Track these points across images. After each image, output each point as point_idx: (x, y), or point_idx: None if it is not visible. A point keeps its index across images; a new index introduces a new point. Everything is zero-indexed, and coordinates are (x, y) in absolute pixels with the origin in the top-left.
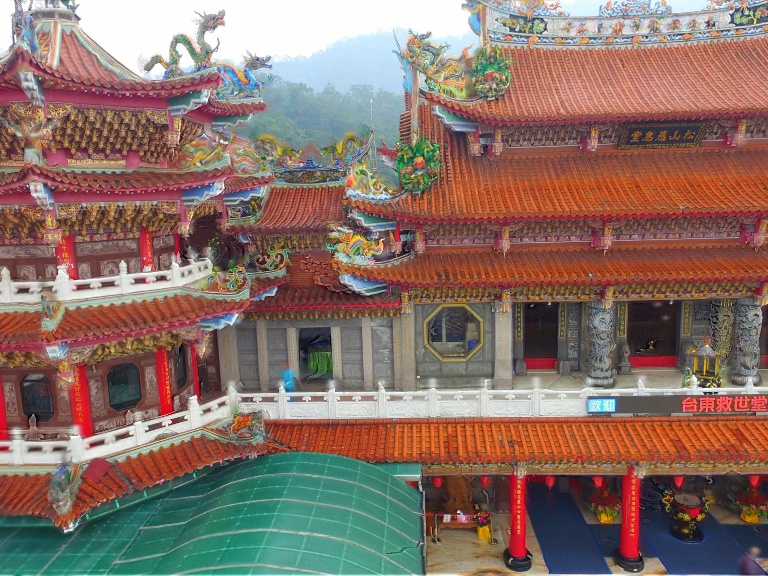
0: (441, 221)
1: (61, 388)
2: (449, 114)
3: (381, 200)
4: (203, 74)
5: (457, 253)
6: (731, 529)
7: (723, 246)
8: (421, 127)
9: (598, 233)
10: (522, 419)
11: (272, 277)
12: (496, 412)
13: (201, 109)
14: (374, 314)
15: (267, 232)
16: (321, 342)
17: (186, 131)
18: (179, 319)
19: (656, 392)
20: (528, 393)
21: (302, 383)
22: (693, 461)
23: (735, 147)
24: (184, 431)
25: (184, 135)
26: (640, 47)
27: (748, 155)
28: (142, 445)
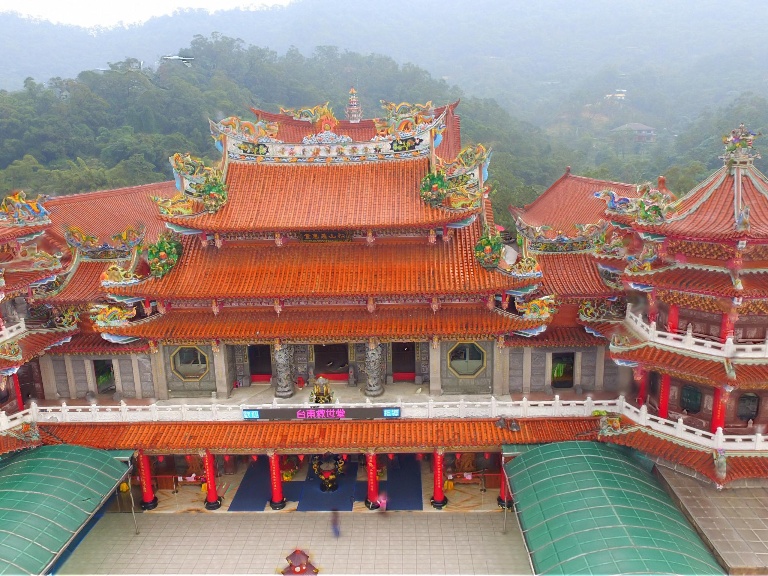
0: (167, 298)
1: None
2: (177, 226)
3: (131, 284)
4: None
5: (191, 312)
6: (359, 484)
7: (357, 309)
8: None
9: None
10: (205, 422)
11: (67, 330)
12: (192, 418)
13: None
14: (136, 352)
15: (60, 303)
16: None
17: None
18: None
19: (284, 406)
20: (209, 407)
21: (99, 393)
22: None
23: (373, 243)
24: None
25: None
26: (332, 165)
27: (380, 248)
28: None
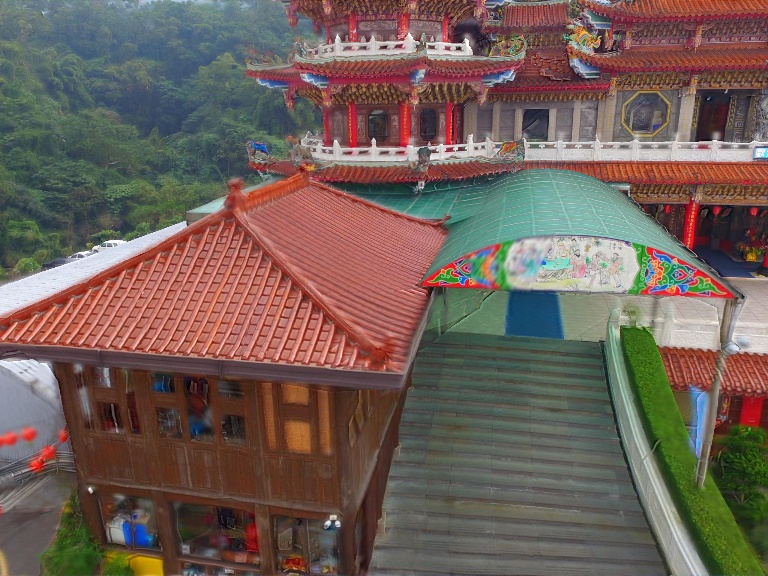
0: (650, 19)
1: (394, 119)
2: None
3: (604, 4)
4: None
5: (655, 51)
6: None
7: None
8: None
9: None
10: (702, 162)
11: None
12: (682, 158)
13: None
14: (586, 97)
15: (514, 30)
16: (528, 134)
17: None
18: (479, 70)
19: None
20: (709, 144)
21: None
22: None
23: None
24: (465, 156)
25: None
26: None
27: None
28: (444, 159)
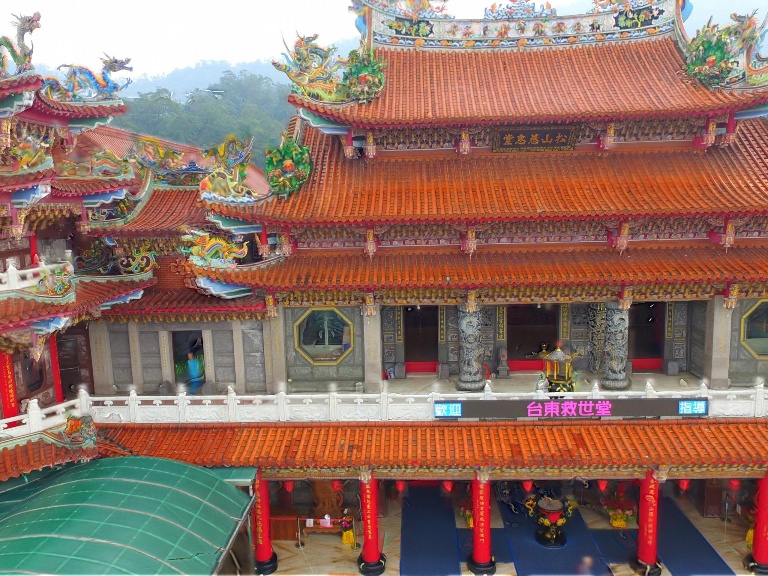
0: (301, 224)
1: None
2: (315, 117)
3: (243, 203)
4: (23, 76)
5: (328, 256)
6: (597, 534)
7: (591, 250)
8: (305, 130)
9: (466, 236)
10: (369, 423)
11: (137, 280)
12: (345, 416)
13: (42, 111)
14: (242, 317)
15: (130, 235)
16: None
17: (32, 133)
18: (1, 322)
19: (503, 396)
20: (376, 397)
21: (177, 386)
22: (527, 466)
23: (608, 150)
24: (21, 435)
25: (30, 137)
26: (526, 50)
27: (621, 158)
28: None
